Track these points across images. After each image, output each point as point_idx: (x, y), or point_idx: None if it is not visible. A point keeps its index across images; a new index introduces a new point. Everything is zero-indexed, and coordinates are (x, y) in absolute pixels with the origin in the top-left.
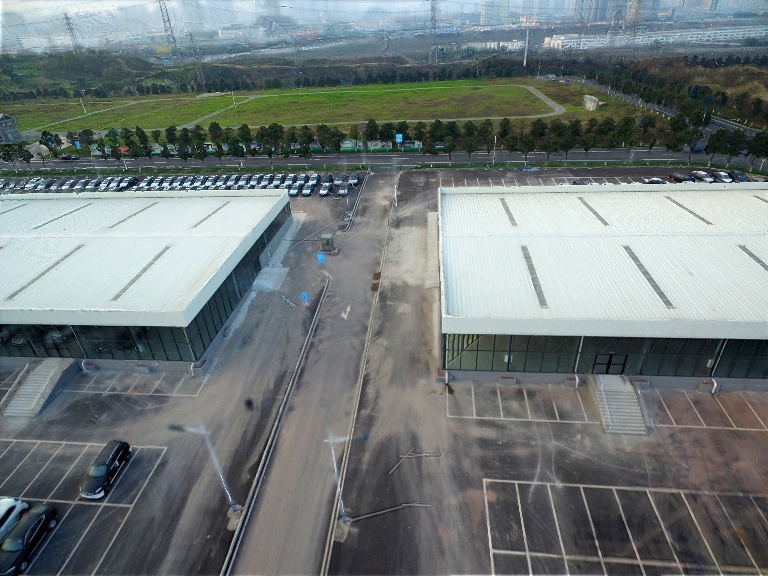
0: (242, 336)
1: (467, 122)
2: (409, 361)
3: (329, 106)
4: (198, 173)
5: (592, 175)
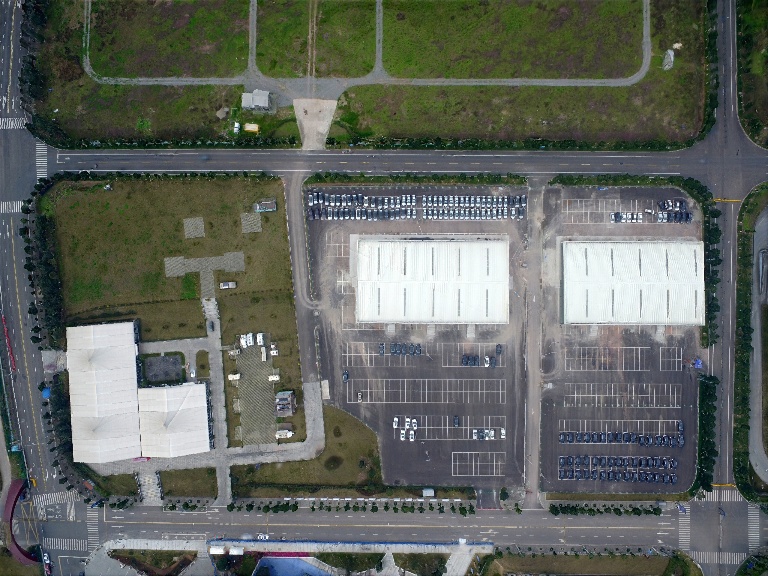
0: (509, 310)
1: (582, 141)
2: (552, 318)
3: (473, 8)
4: (441, 184)
5: (628, 197)
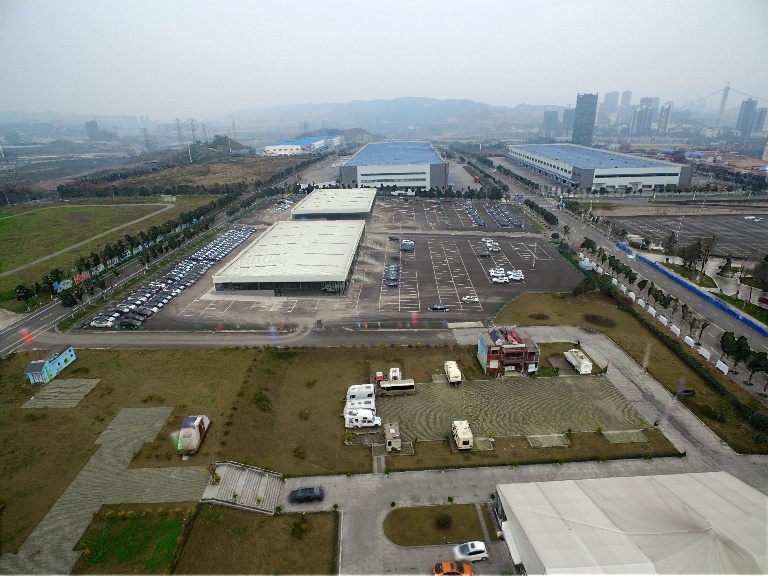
0: None
1: (204, 205)
2: None
3: None
4: None
5: None
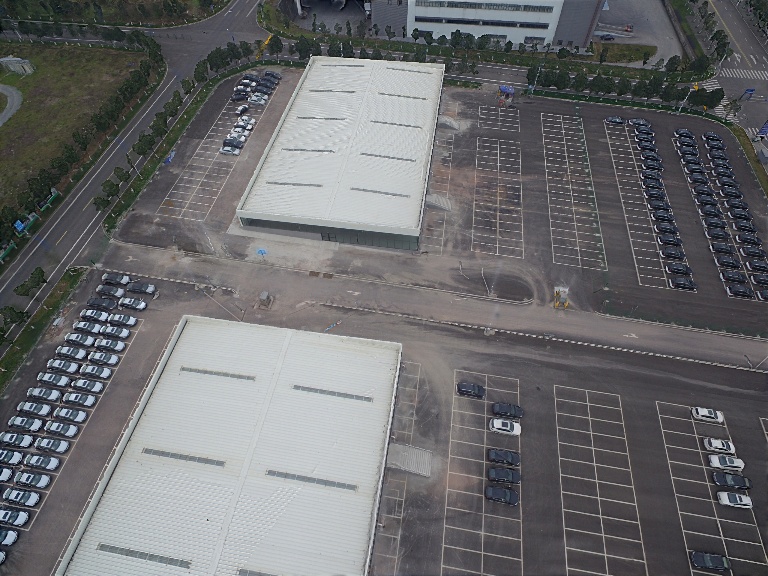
0: None
1: (51, 160)
2: (404, 265)
3: None
4: None
5: (205, 131)
